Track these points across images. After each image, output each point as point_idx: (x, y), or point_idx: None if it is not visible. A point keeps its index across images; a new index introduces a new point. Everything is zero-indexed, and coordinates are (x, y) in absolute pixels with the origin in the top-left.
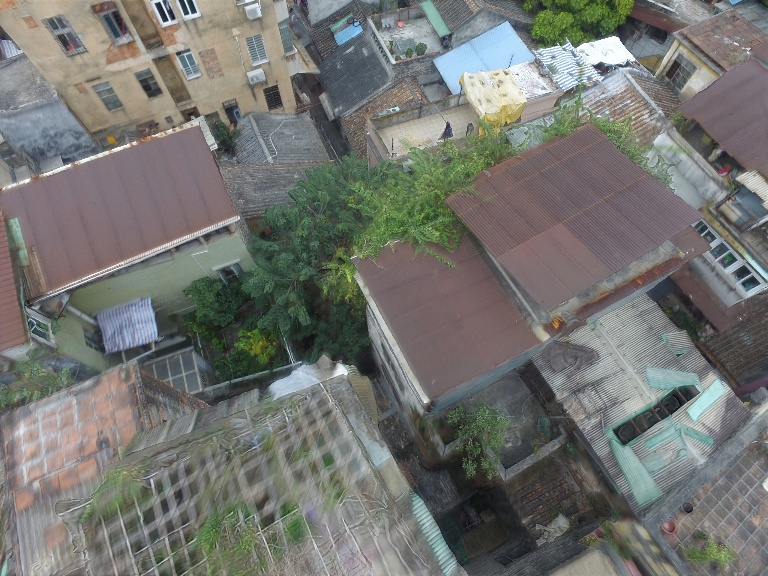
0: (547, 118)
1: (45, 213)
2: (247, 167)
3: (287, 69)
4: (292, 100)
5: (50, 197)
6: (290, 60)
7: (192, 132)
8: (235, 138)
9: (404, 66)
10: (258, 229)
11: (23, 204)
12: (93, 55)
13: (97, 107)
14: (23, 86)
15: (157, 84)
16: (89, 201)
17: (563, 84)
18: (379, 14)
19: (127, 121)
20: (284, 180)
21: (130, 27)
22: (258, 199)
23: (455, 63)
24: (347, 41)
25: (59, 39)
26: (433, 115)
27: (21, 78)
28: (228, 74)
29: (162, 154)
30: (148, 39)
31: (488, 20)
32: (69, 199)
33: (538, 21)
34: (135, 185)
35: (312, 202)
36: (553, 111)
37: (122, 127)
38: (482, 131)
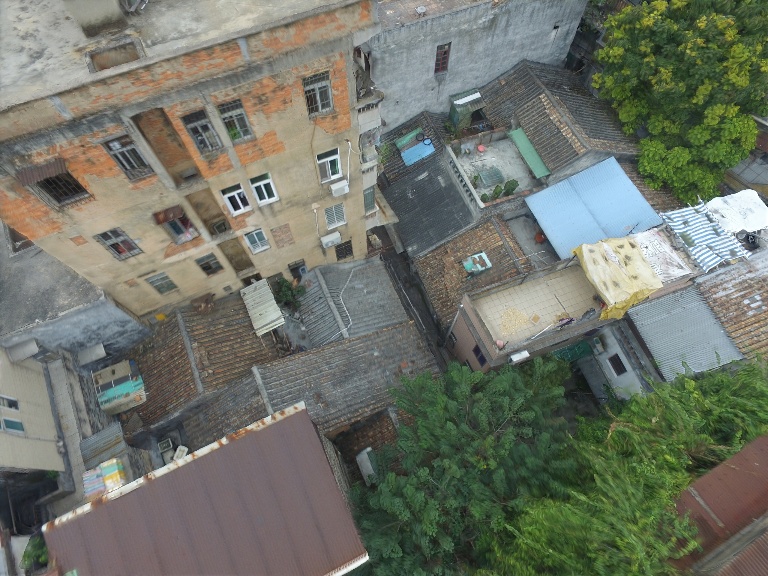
0: (678, 294)
1: (112, 557)
2: (322, 351)
3: (364, 225)
4: (364, 248)
5: (118, 531)
6: (369, 218)
7: (297, 419)
8: (299, 295)
9: (493, 208)
10: (338, 432)
11: (83, 545)
12: (150, 254)
13: (148, 294)
14: (62, 282)
15: (219, 263)
16: (169, 535)
17: (703, 262)
18: (459, 140)
19: (180, 298)
20: (364, 363)
21: (196, 223)
22: (338, 398)
23: (552, 205)
24: (417, 161)
25: (111, 247)
26: (536, 280)
27: (59, 270)
28: (299, 241)
29: (260, 455)
30: (212, 219)
31: (593, 158)
32: (143, 533)
33: (647, 155)
34: (228, 507)
35: (425, 451)
36: (685, 286)
37: (174, 304)
38: (604, 314)
